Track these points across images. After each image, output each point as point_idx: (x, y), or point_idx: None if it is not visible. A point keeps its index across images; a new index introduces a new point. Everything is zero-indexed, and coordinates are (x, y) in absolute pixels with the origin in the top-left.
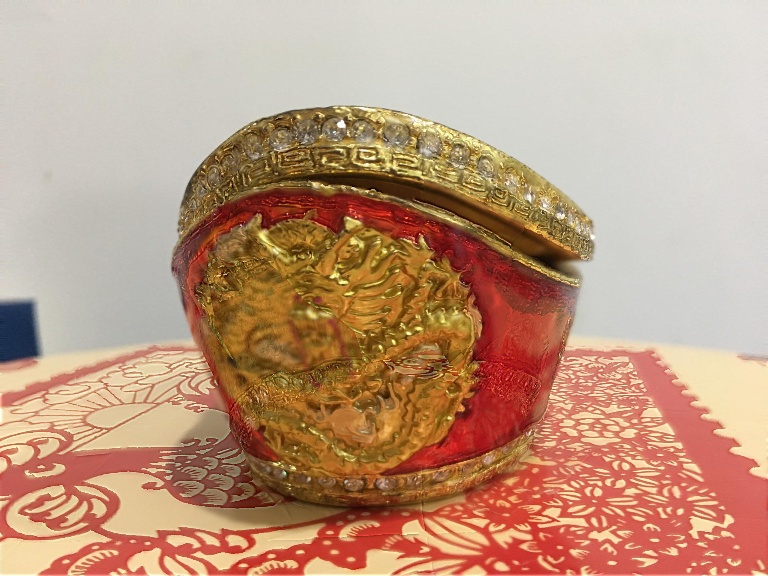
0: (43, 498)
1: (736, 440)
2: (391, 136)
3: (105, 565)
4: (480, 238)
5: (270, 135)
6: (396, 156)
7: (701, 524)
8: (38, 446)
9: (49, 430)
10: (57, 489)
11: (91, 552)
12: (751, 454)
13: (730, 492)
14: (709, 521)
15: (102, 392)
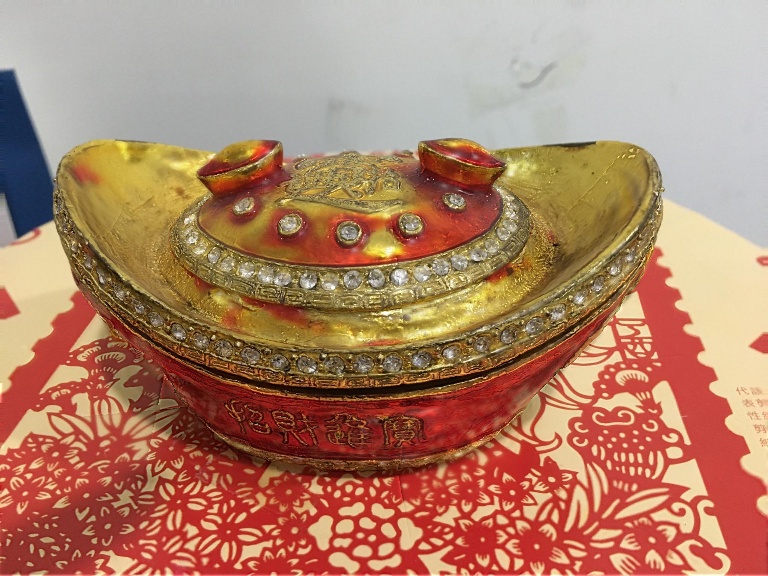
0: None
1: None
2: None
3: None
4: None
5: None
6: None
7: (120, 562)
8: None
9: None
10: None
11: None
12: None
13: None
14: (124, 570)
15: None
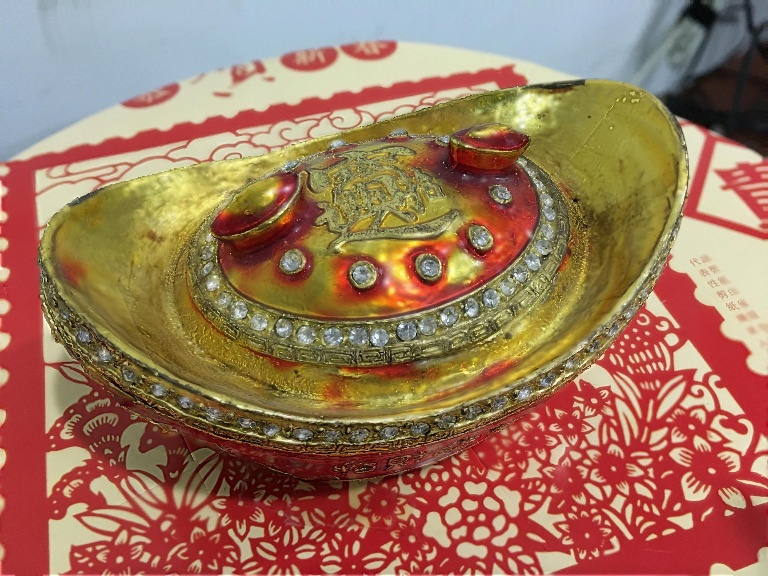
0: None
1: None
2: None
3: None
4: (131, 402)
5: None
6: None
7: None
8: None
9: None
10: None
11: None
12: None
13: None
14: None
15: None
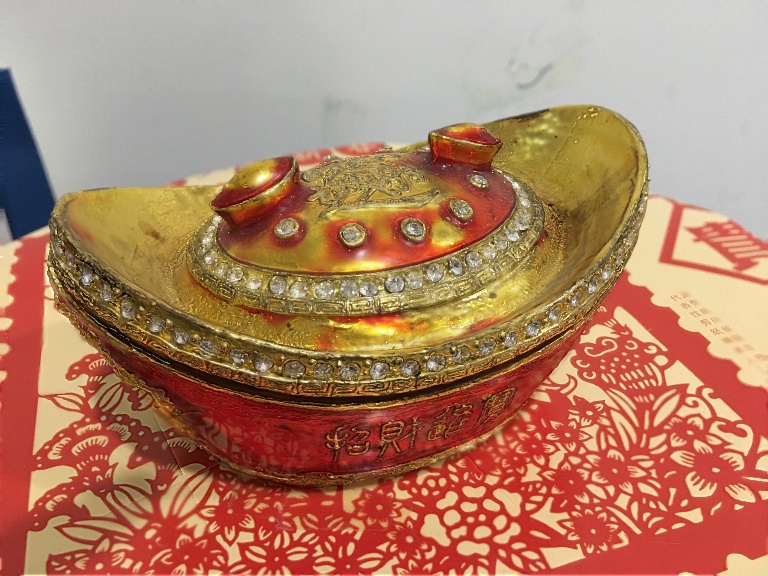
0: None
1: None
2: None
3: (103, 370)
4: (126, 351)
5: None
6: None
7: None
8: None
9: None
10: None
11: None
12: None
13: None
14: None
15: None
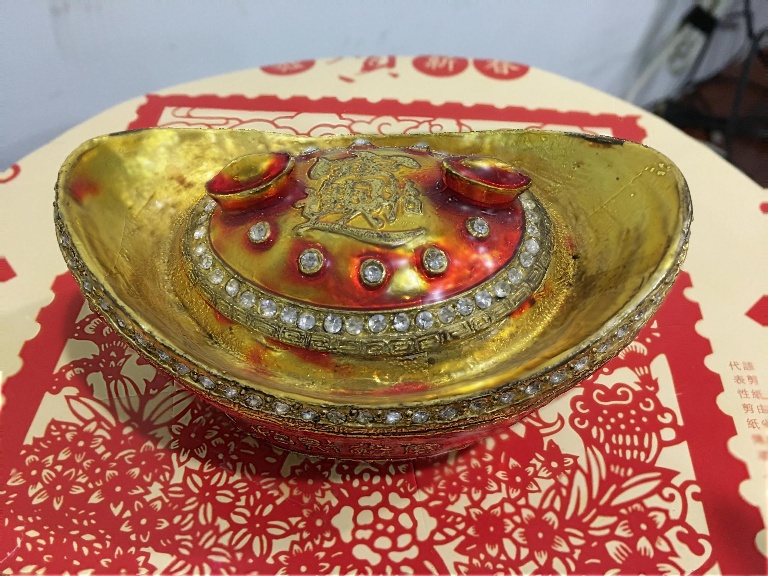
0: None
1: None
2: None
3: None
4: None
5: None
6: None
7: (160, 559)
8: None
9: None
10: None
11: None
12: None
13: None
14: (165, 567)
15: None
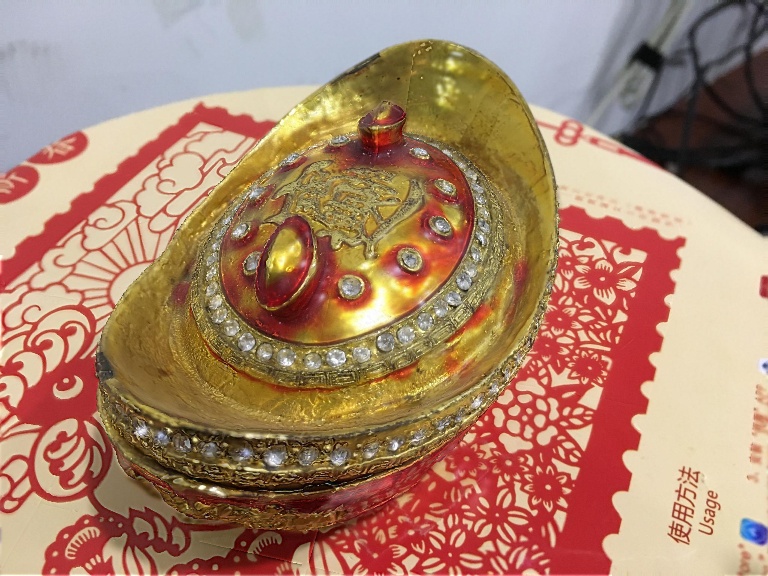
0: (61, 437)
1: (631, 478)
2: (235, 454)
3: (89, 548)
4: (330, 495)
5: (132, 419)
6: (238, 473)
7: None
8: (68, 338)
9: (79, 308)
10: (72, 425)
11: (83, 528)
12: (625, 510)
13: (563, 572)
14: None
15: (132, 230)
